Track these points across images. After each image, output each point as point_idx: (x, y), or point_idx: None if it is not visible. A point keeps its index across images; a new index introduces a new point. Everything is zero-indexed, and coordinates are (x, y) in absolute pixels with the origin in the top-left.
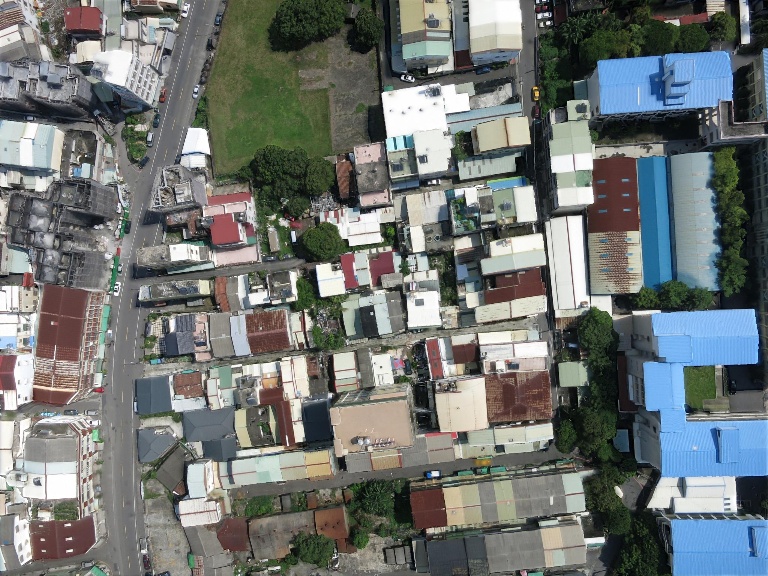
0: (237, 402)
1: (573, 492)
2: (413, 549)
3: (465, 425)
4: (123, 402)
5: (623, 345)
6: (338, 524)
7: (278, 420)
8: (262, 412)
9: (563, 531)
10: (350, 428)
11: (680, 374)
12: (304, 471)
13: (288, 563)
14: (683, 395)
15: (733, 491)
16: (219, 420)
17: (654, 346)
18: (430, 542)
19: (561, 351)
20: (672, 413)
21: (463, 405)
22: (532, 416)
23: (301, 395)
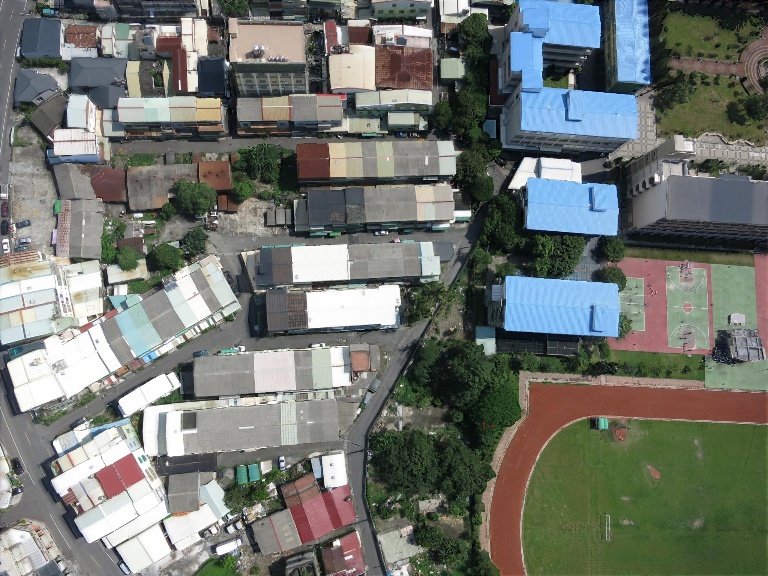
0: (131, 58)
1: (446, 154)
2: (294, 207)
3: (354, 82)
4: (4, 49)
5: (496, 50)
6: (222, 172)
7: (173, 66)
8: (156, 66)
9: (435, 189)
10: (246, 43)
11: (539, 48)
12: (193, 113)
13: (165, 211)
14: (541, 65)
15: (579, 179)
16: (110, 65)
17: (520, 22)
18: (312, 190)
19: (444, 54)
20: (532, 73)
21: (354, 65)
22: (415, 85)
23: (199, 53)
